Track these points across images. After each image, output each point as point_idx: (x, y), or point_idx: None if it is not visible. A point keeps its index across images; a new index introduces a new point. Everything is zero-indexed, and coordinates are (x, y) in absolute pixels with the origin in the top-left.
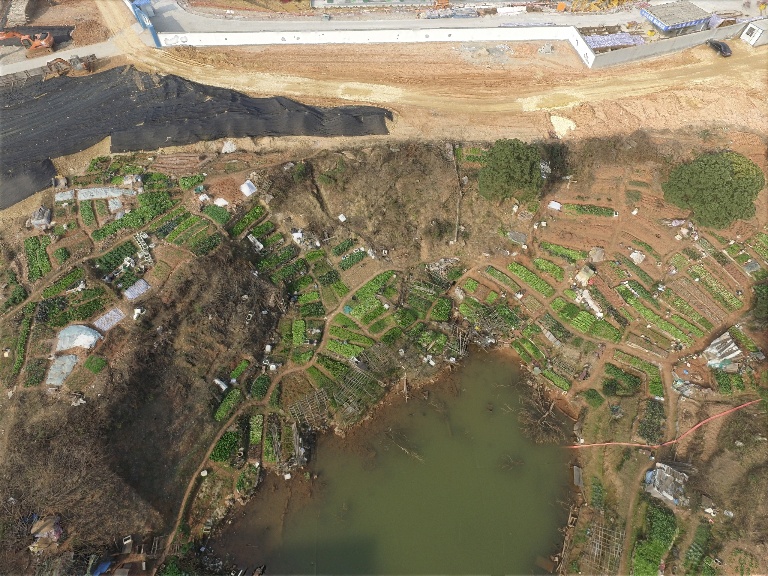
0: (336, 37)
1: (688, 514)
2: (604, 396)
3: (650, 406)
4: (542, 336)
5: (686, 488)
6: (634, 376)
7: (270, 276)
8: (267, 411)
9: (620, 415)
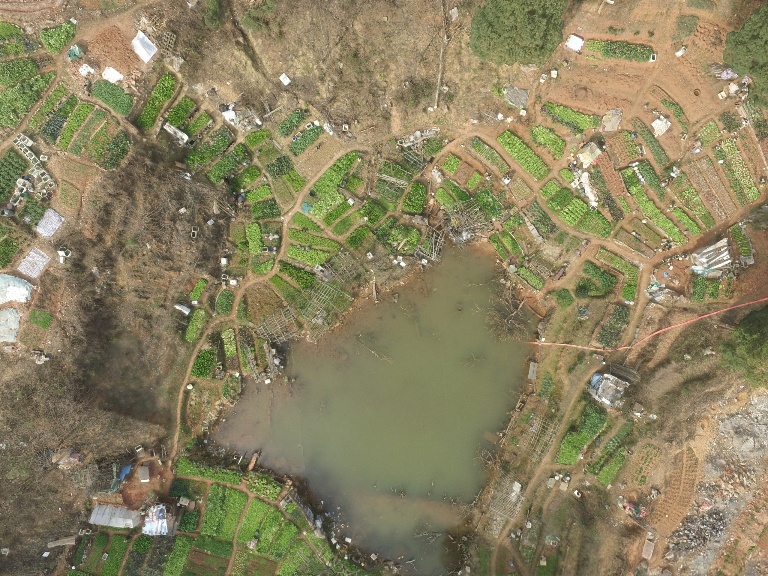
0: None
1: (619, 414)
2: (575, 297)
3: (617, 312)
4: (525, 229)
5: (624, 395)
6: (611, 275)
7: (206, 173)
8: (237, 325)
9: (586, 317)
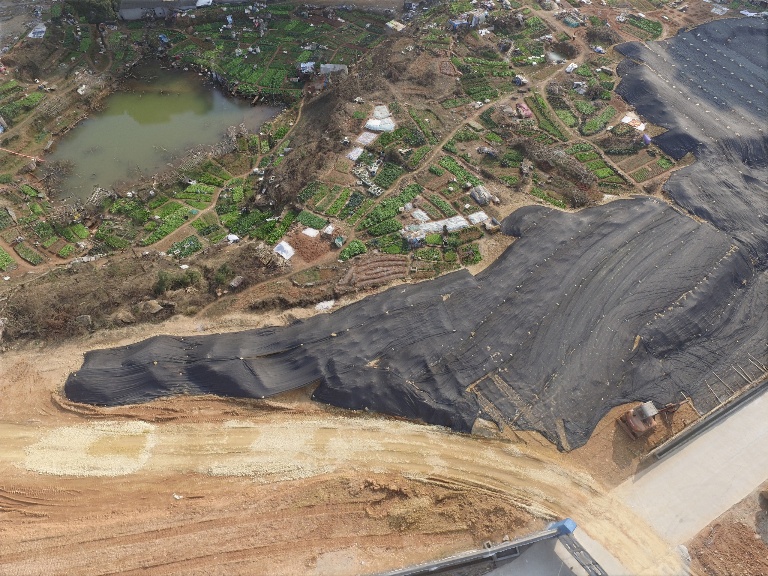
0: None
1: None
2: None
3: None
4: None
5: None
6: None
7: None
8: None
9: None
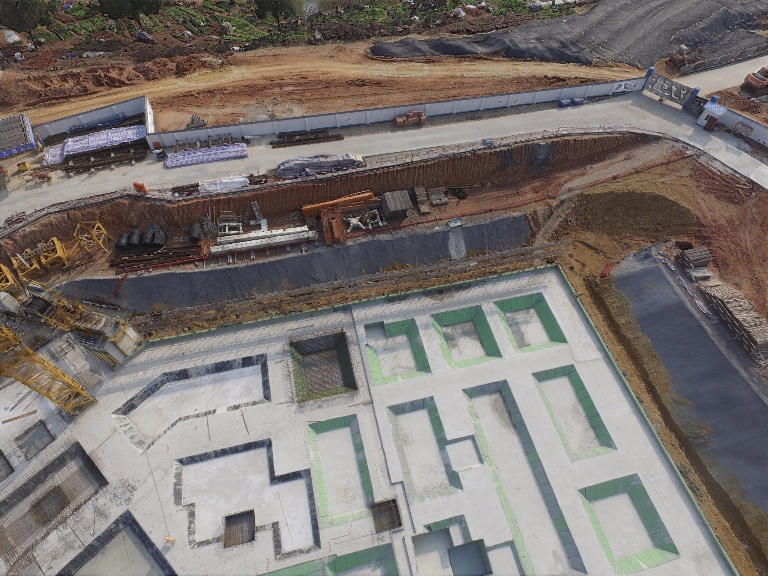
0: (458, 106)
1: None
2: None
3: None
4: None
5: None
6: None
7: None
8: None
9: None
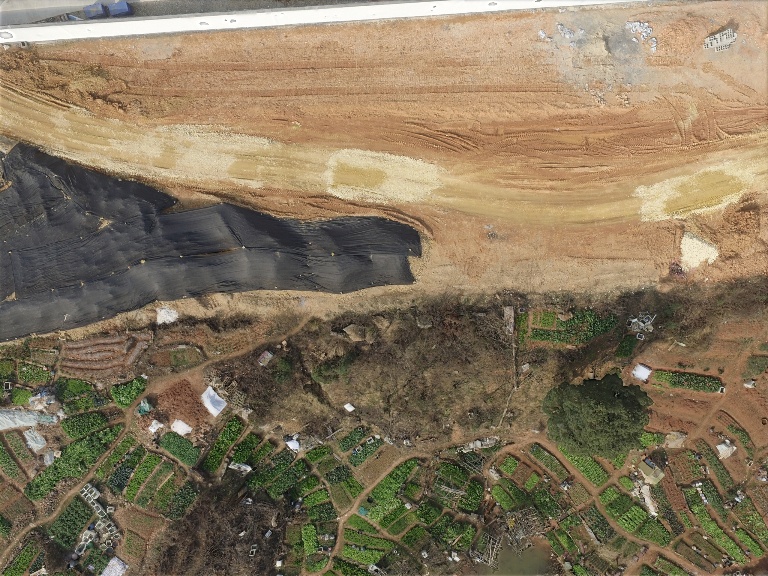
0: (309, 16)
1: None
2: None
3: None
4: (581, 529)
5: None
6: None
7: (266, 490)
8: None
9: None
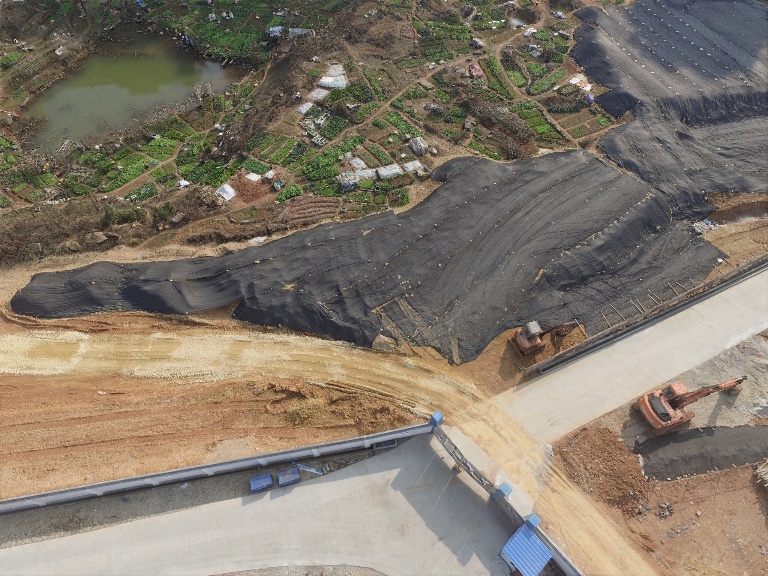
0: None
1: None
2: None
3: None
4: None
5: None
6: None
7: None
8: None
9: None
